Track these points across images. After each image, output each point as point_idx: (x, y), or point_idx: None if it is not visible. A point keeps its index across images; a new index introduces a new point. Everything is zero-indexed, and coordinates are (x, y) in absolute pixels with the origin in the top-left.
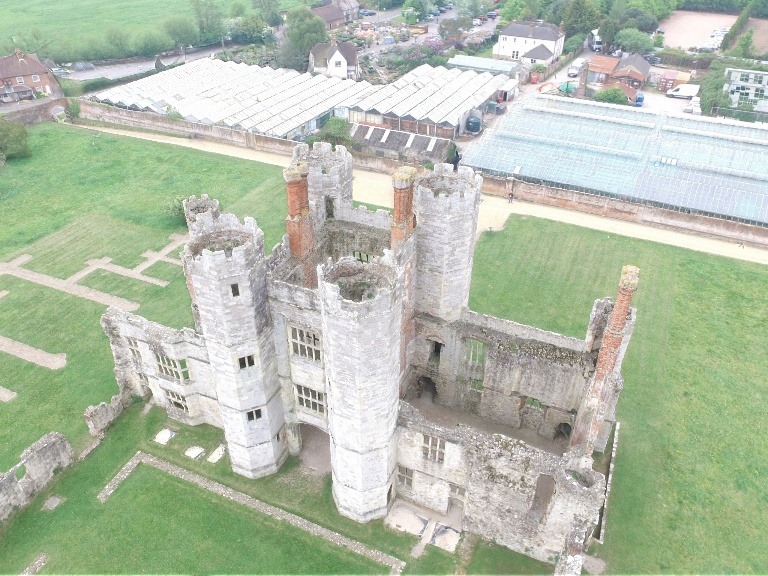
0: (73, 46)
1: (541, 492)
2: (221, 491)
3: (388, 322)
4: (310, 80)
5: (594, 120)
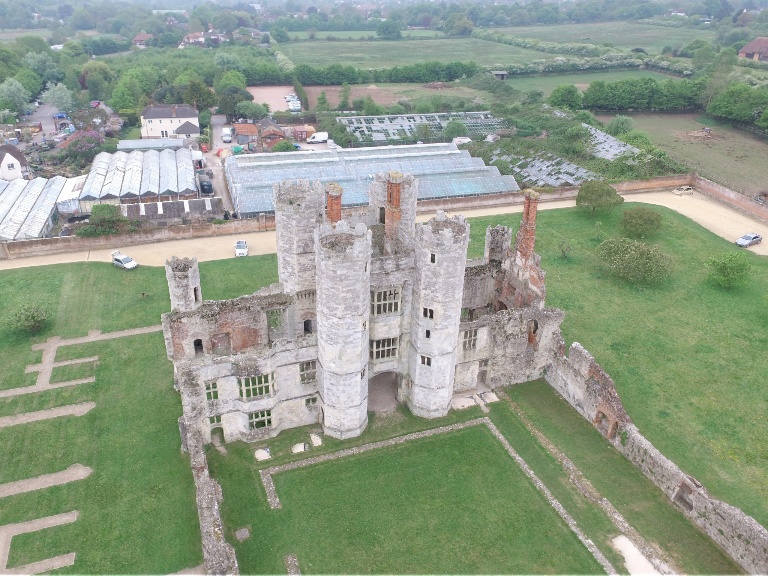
0: None
1: None
2: (350, 452)
3: None
4: None
5: (297, 164)
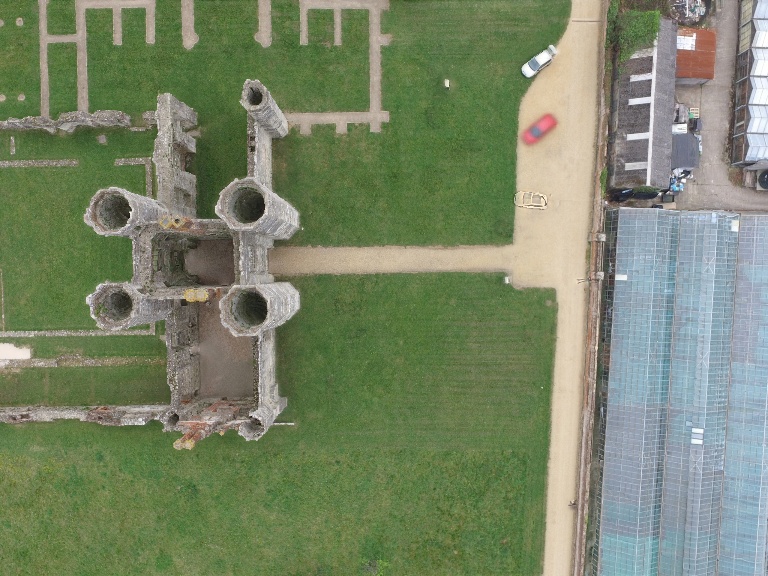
0: None
1: (226, 389)
2: None
3: None
4: None
5: None
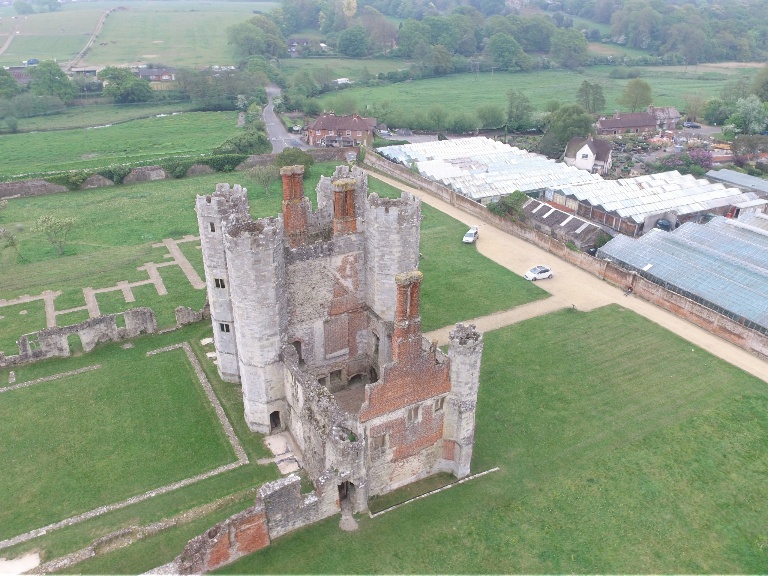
0: (404, 117)
1: None
2: (202, 378)
3: (251, 260)
4: (548, 165)
5: None
